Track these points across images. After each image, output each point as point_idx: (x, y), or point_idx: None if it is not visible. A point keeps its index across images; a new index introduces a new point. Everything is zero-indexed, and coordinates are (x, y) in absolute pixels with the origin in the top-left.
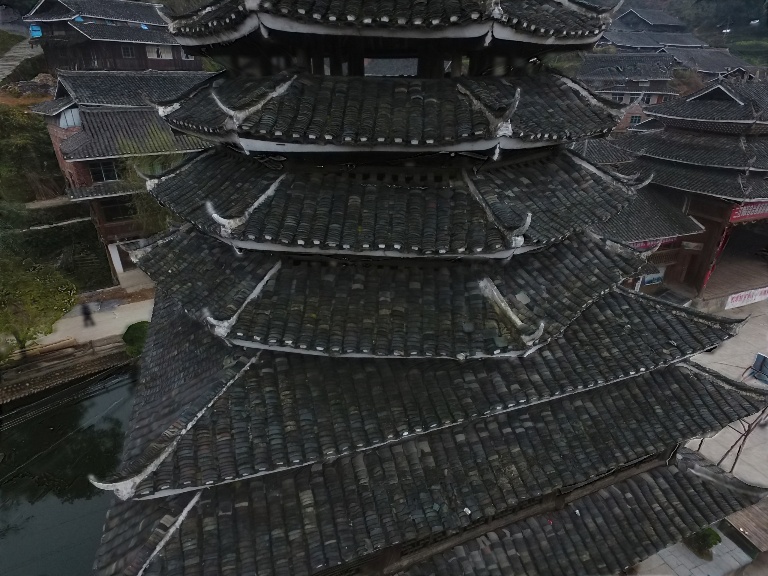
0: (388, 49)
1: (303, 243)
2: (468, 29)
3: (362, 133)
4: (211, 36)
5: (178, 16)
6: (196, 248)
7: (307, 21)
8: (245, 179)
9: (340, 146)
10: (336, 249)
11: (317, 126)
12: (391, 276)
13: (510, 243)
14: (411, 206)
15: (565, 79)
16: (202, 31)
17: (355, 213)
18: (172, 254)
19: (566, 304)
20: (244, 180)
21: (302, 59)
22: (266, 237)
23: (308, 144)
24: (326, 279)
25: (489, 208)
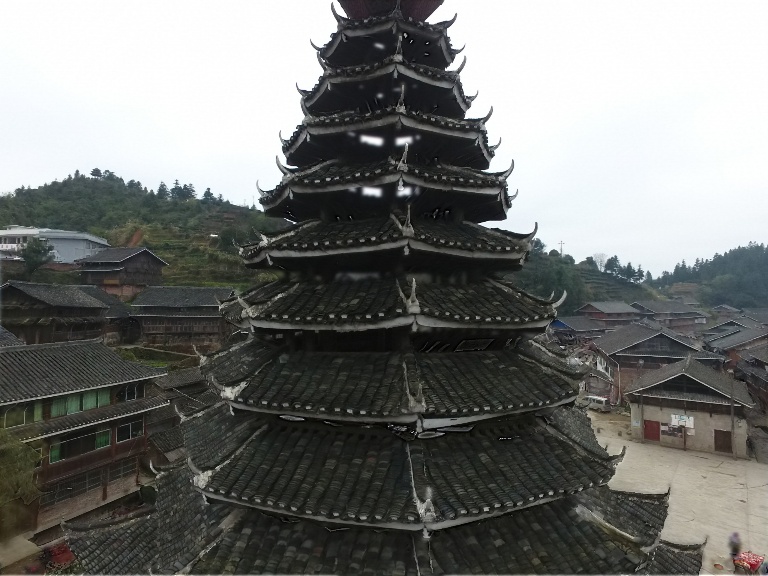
0: (487, 335)
1: (488, 509)
2: (540, 323)
3: (506, 401)
4: (329, 325)
5: (256, 302)
6: (268, 548)
7: (449, 320)
8: (360, 454)
9: (492, 414)
10: (511, 508)
11: (469, 399)
12: (514, 523)
13: (614, 471)
14: (526, 454)
15: (530, 340)
16: (317, 320)
17: (497, 470)
18: (232, 566)
19: (612, 512)
20: (360, 455)
21: (418, 343)
22: (462, 512)
23: (472, 416)
24: (471, 543)
25: (579, 445)
